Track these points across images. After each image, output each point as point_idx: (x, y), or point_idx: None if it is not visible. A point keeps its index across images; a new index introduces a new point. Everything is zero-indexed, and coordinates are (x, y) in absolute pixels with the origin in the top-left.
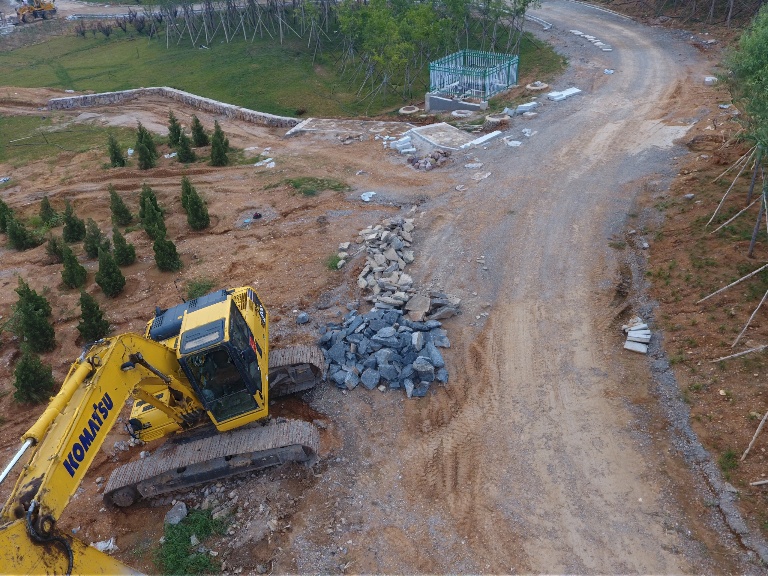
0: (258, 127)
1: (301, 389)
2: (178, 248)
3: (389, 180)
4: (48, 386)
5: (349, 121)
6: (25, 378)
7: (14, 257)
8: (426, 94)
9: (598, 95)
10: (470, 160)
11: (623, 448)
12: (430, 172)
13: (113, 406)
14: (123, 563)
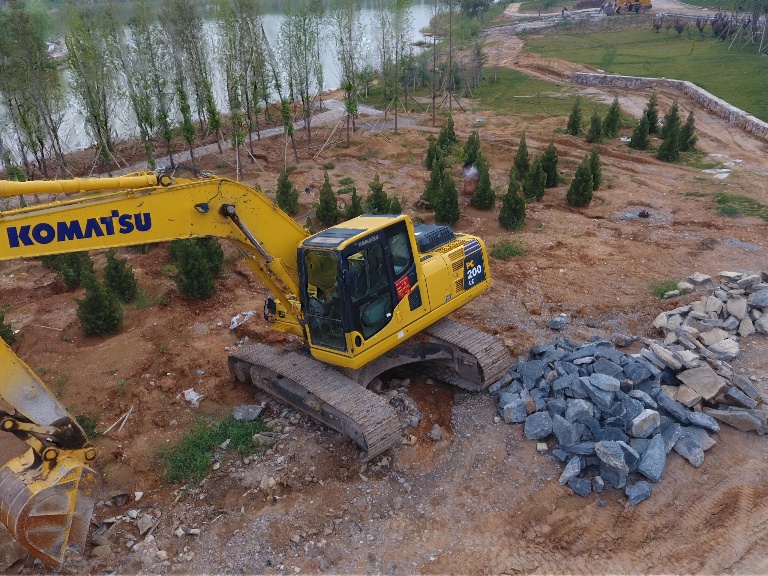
0: (753, 139)
1: (460, 384)
2: (537, 213)
3: None
4: None
5: None
6: None
7: (418, 172)
8: None
9: None
10: None
11: None
12: None
13: (149, 230)
14: (27, 368)
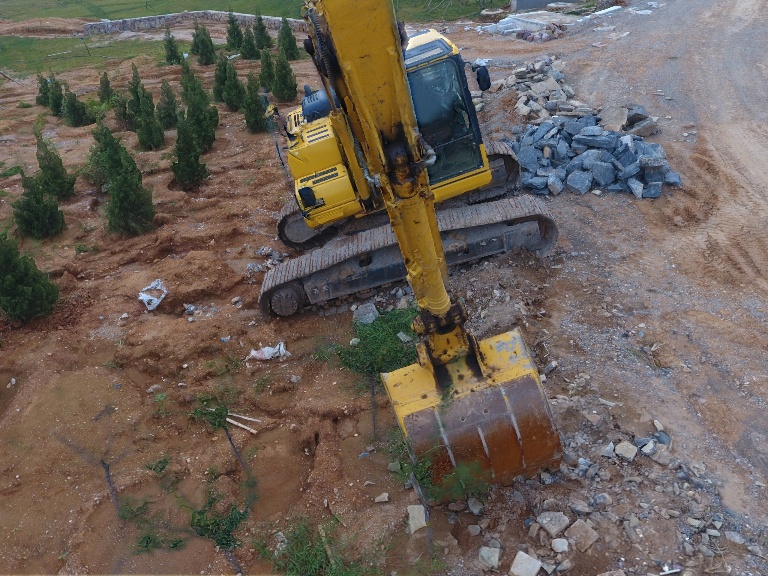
0: None
1: (489, 196)
2: None
3: (500, 52)
4: (149, 214)
5: (425, 24)
6: (124, 197)
7: (74, 130)
8: None
9: None
10: (598, 24)
11: None
12: (548, 42)
13: None
14: None
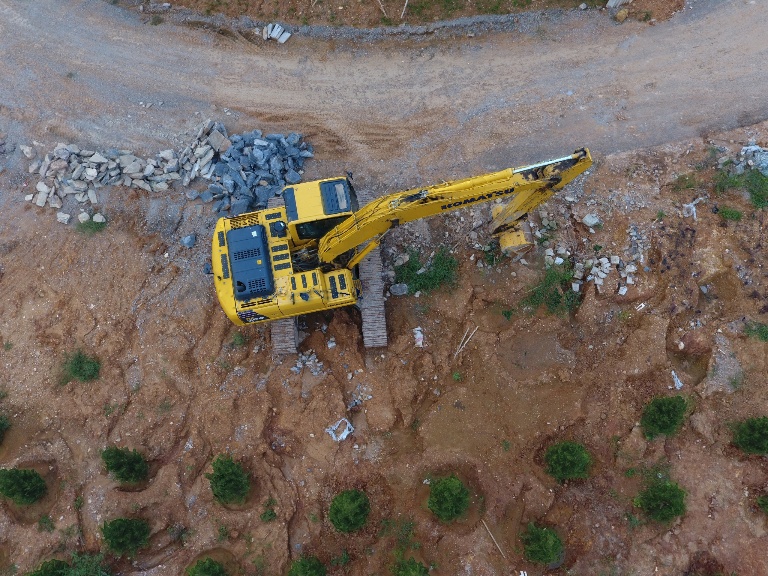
0: None
1: None
2: None
3: None
4: None
5: None
6: None
7: None
8: None
9: None
10: None
11: (368, 61)
12: None
13: None
14: None
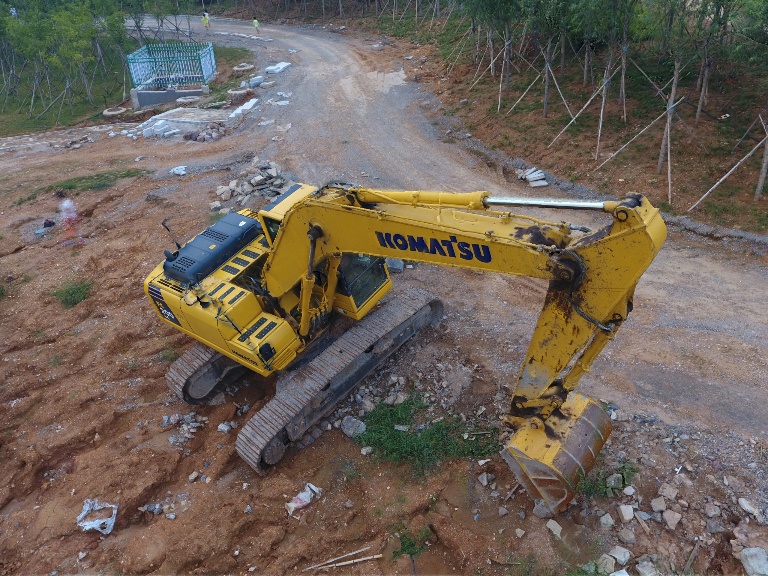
0: None
1: None
2: None
3: (182, 156)
4: None
5: (47, 133)
6: None
7: None
8: (131, 90)
9: (307, 65)
10: (259, 120)
11: None
12: (222, 140)
13: None
14: None
